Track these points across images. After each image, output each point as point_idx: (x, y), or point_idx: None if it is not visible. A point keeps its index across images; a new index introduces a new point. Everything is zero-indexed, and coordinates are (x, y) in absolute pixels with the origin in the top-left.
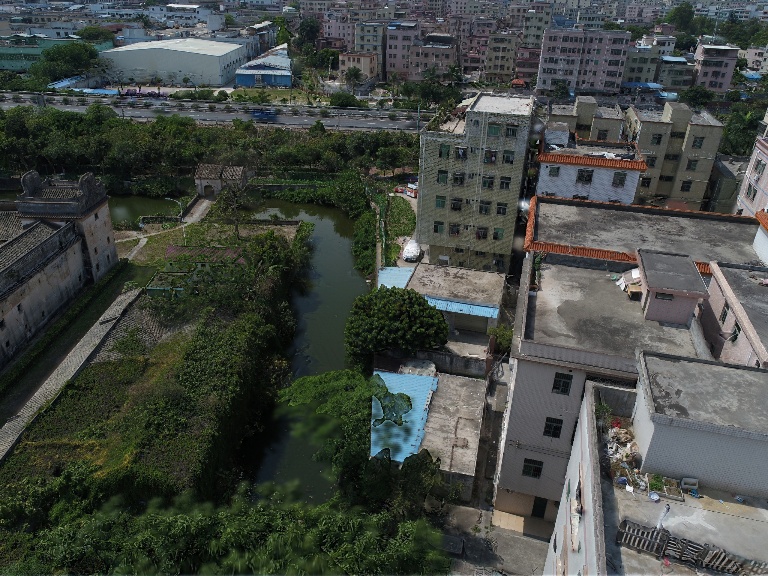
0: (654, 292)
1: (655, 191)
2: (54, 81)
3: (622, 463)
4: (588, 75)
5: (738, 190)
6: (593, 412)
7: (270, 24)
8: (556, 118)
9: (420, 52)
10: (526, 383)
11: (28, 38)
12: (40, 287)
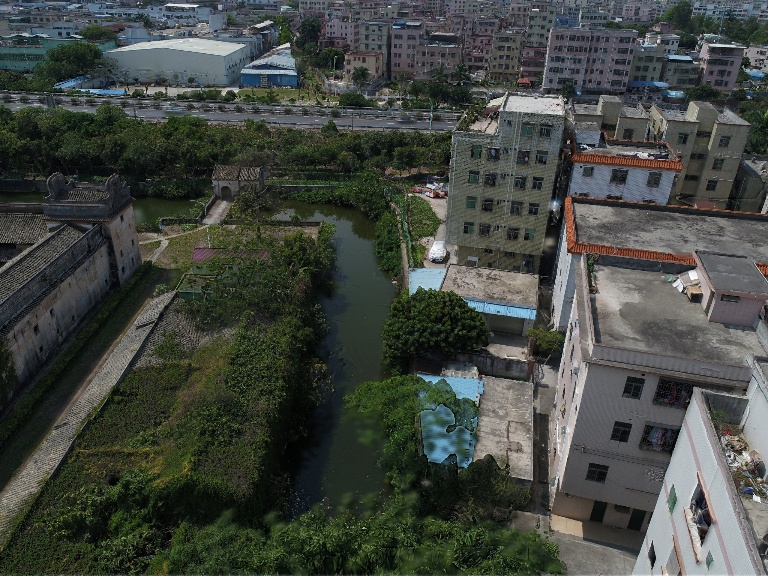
0: (720, 294)
1: (680, 190)
2: (59, 81)
3: (744, 472)
4: (595, 74)
5: (766, 189)
6: (710, 420)
7: (271, 23)
8: (581, 118)
9: (426, 51)
10: (596, 387)
11: (30, 38)
12: (70, 291)
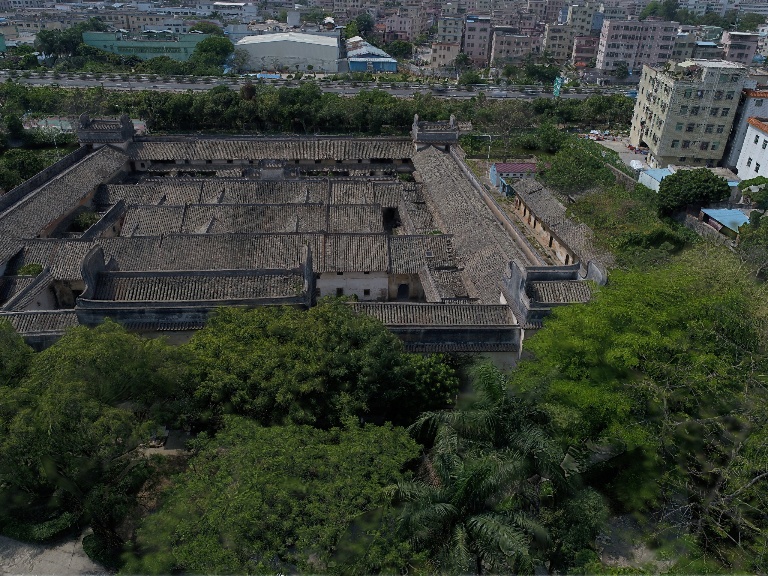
0: None
1: None
2: None
3: None
4: (643, 57)
5: None
6: None
7: (333, 20)
8: None
9: (504, 41)
10: None
11: (158, 34)
12: None
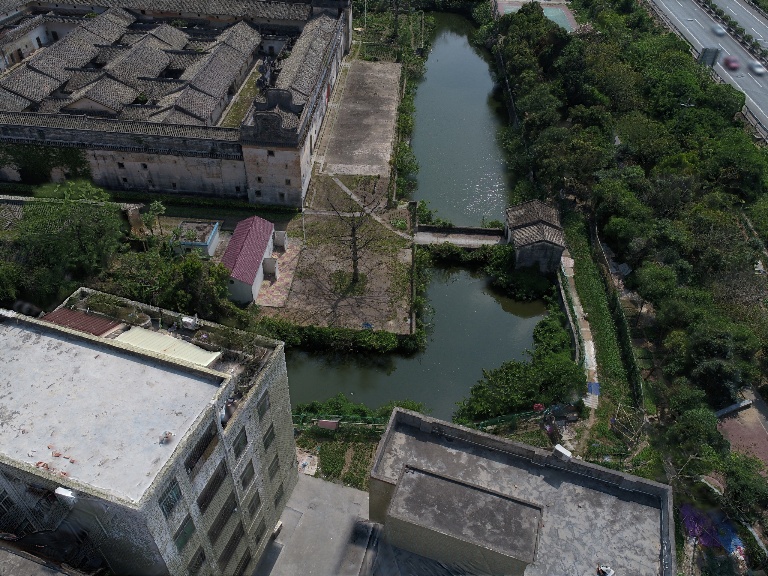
0: None
1: None
2: None
3: None
4: None
5: None
6: None
7: None
8: None
9: None
10: None
11: None
12: (175, 166)
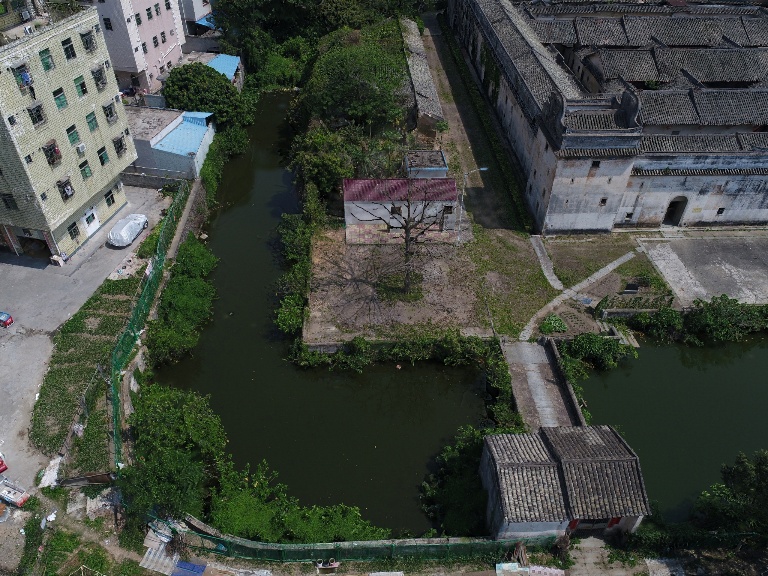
0: None
1: None
2: None
3: None
4: None
5: None
6: None
7: None
8: None
9: None
10: None
11: None
12: None
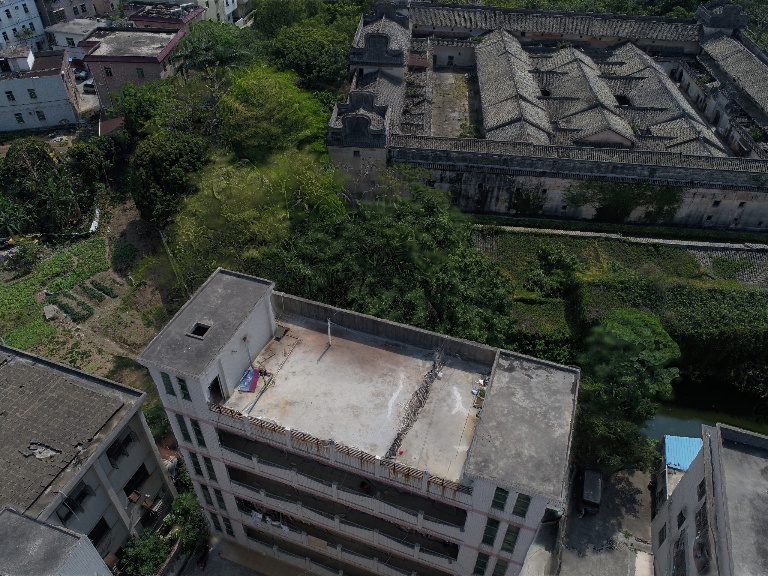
0: None
1: None
2: None
3: None
4: None
5: None
6: None
7: None
8: None
9: None
10: None
11: None
12: None
